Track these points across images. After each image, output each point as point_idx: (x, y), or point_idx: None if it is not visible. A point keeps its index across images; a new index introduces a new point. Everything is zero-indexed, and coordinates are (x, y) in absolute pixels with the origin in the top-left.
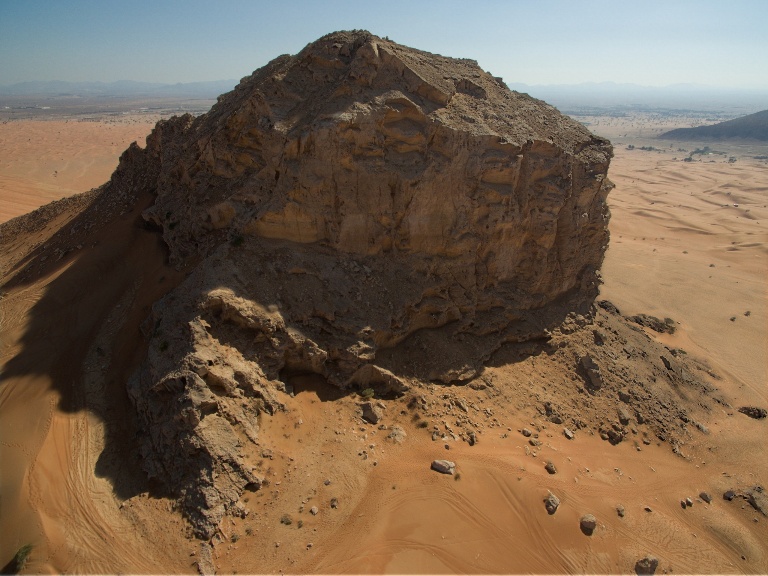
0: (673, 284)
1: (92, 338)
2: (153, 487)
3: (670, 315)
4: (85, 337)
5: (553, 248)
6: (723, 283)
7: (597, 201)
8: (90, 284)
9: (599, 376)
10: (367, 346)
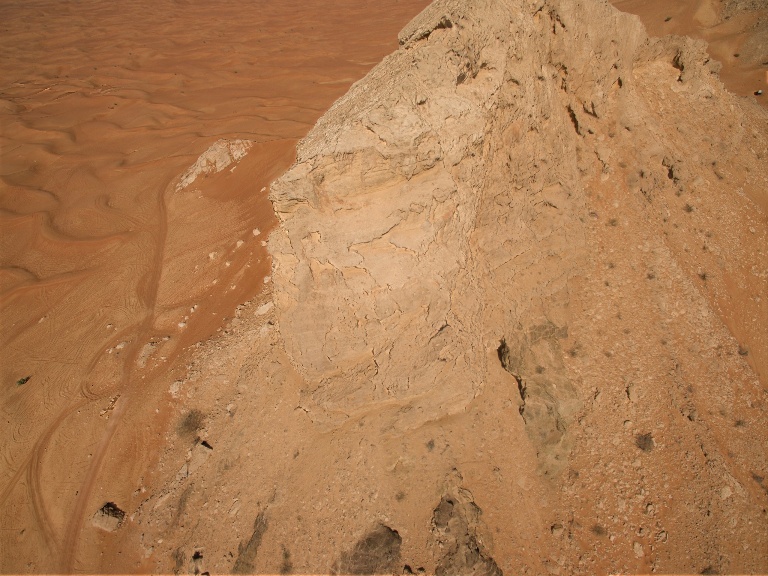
0: None
1: None
2: None
3: None
4: None
5: None
6: None
7: None
8: None
9: None
10: None
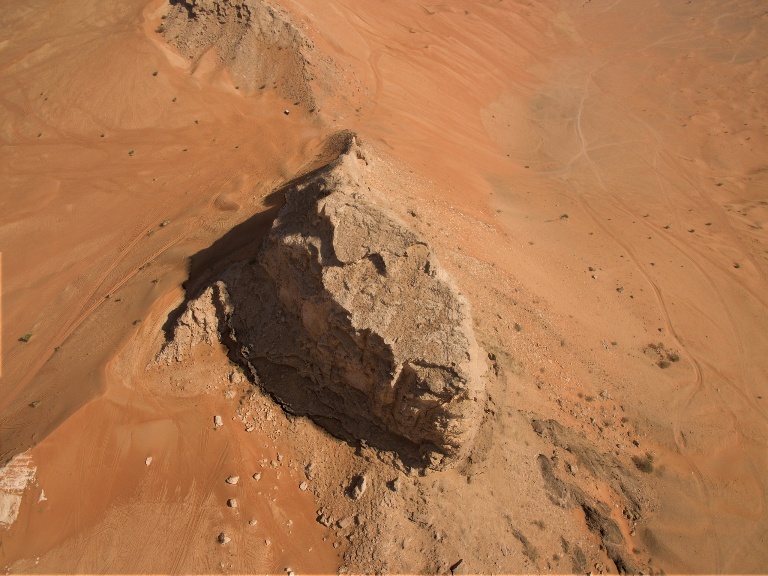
0: None
1: (219, 260)
2: (168, 332)
3: None
4: (218, 258)
5: (389, 405)
6: None
7: None
8: (252, 229)
9: (355, 493)
10: (248, 352)
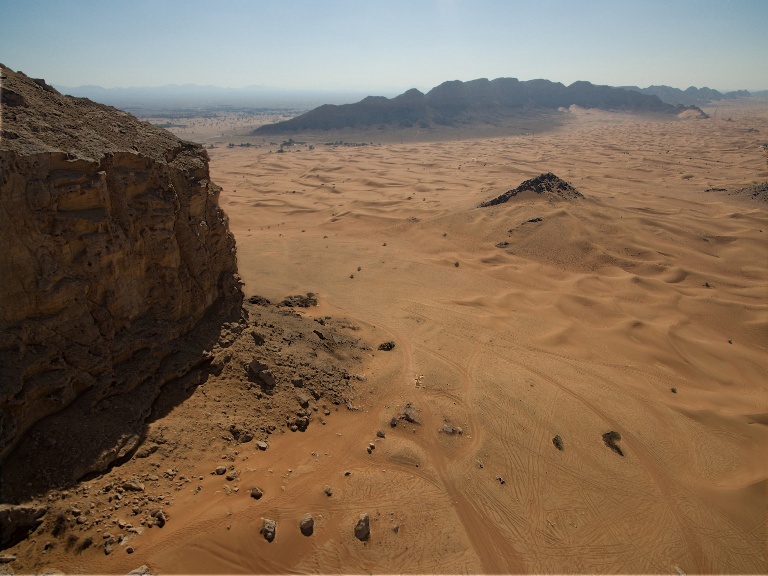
0: (303, 261)
1: None
2: None
3: (310, 289)
4: None
5: (181, 266)
6: (337, 249)
7: (210, 207)
8: None
9: (271, 375)
10: None
